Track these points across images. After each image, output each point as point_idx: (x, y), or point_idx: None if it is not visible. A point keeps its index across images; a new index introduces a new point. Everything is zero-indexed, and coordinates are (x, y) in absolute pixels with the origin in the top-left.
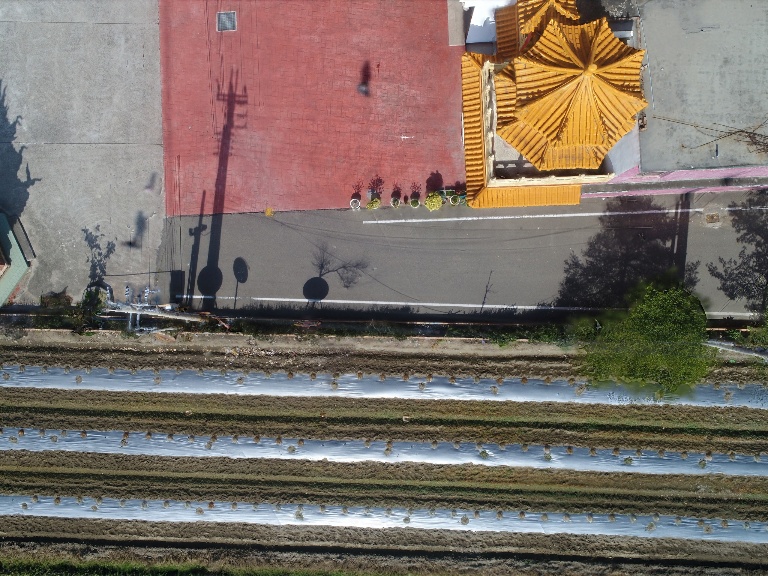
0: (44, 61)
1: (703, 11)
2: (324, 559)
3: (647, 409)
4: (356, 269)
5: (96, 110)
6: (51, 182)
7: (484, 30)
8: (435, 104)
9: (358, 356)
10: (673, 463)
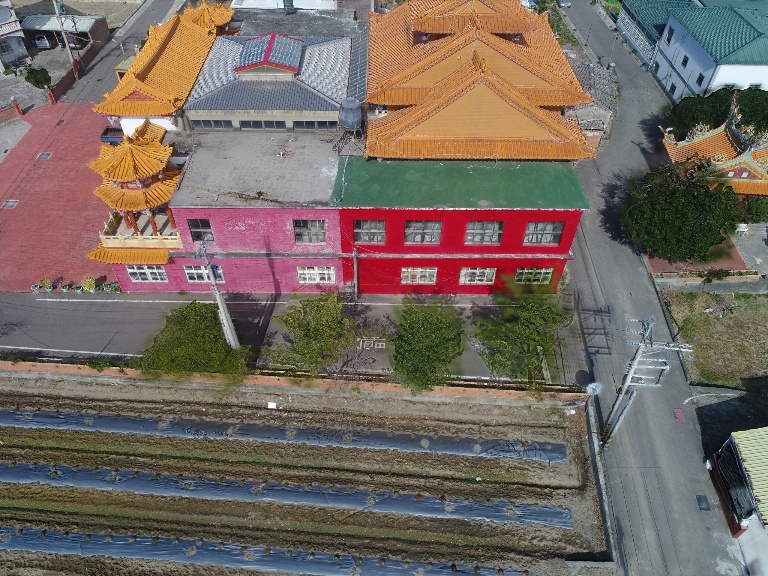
0: None
1: (229, 152)
2: None
3: (218, 442)
4: (14, 326)
5: None
6: None
7: None
8: None
9: None
10: (229, 488)
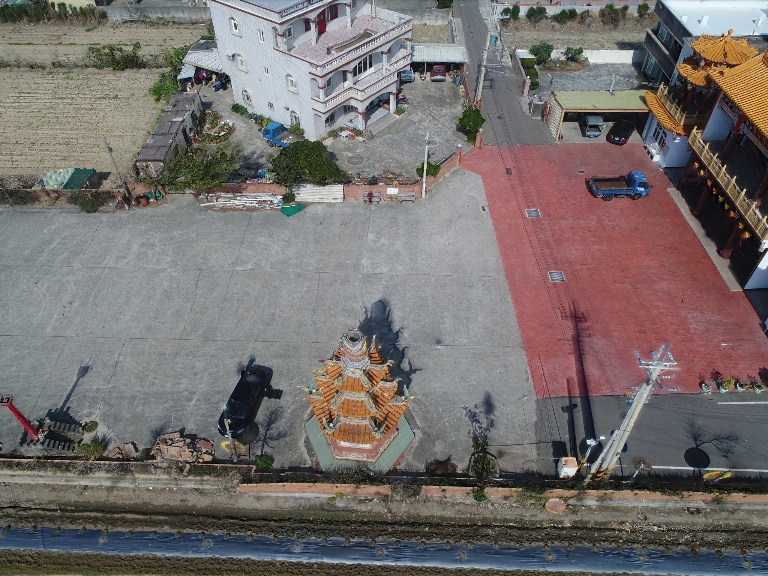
0: (420, 295)
1: None
2: None
3: None
4: (728, 441)
5: (464, 325)
6: (430, 372)
7: (765, 274)
8: (738, 324)
9: (757, 532)
10: None
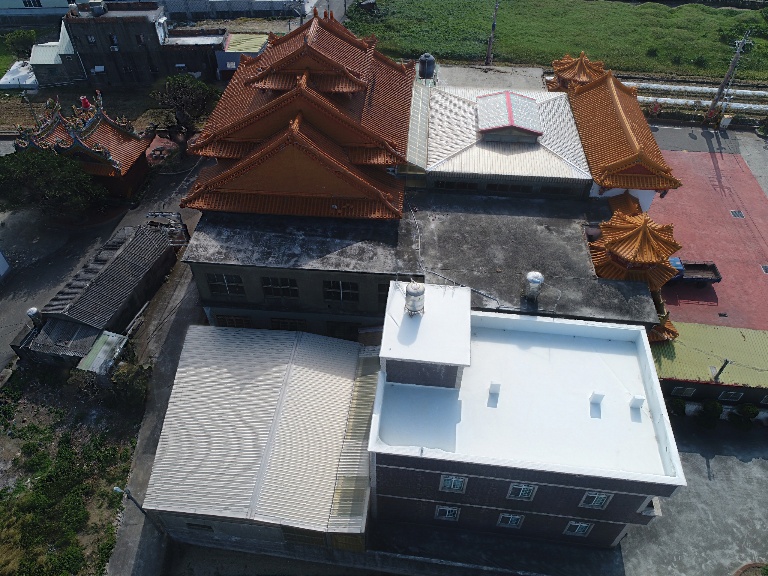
0: None
1: None
2: (625, 75)
3: None
4: None
5: None
6: None
7: None
8: None
9: None
10: None
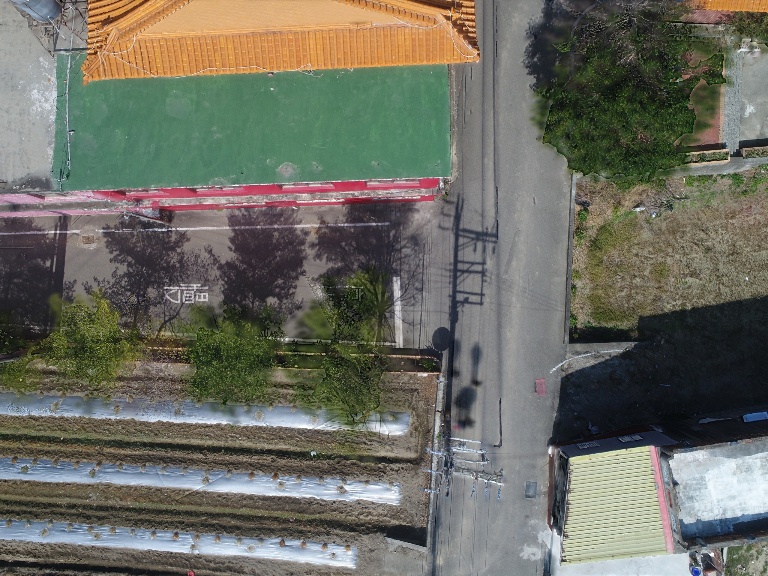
0: None
1: None
2: None
3: (44, 420)
4: None
5: None
6: None
7: None
8: None
9: None
10: (65, 472)
